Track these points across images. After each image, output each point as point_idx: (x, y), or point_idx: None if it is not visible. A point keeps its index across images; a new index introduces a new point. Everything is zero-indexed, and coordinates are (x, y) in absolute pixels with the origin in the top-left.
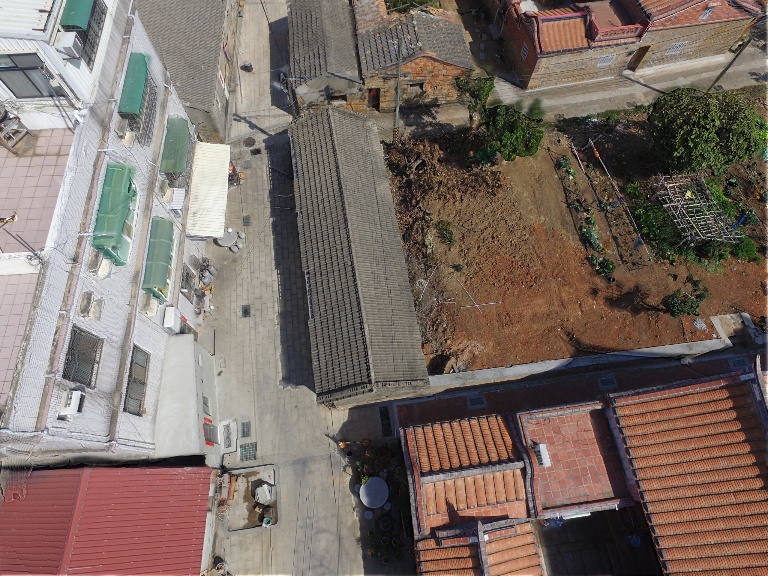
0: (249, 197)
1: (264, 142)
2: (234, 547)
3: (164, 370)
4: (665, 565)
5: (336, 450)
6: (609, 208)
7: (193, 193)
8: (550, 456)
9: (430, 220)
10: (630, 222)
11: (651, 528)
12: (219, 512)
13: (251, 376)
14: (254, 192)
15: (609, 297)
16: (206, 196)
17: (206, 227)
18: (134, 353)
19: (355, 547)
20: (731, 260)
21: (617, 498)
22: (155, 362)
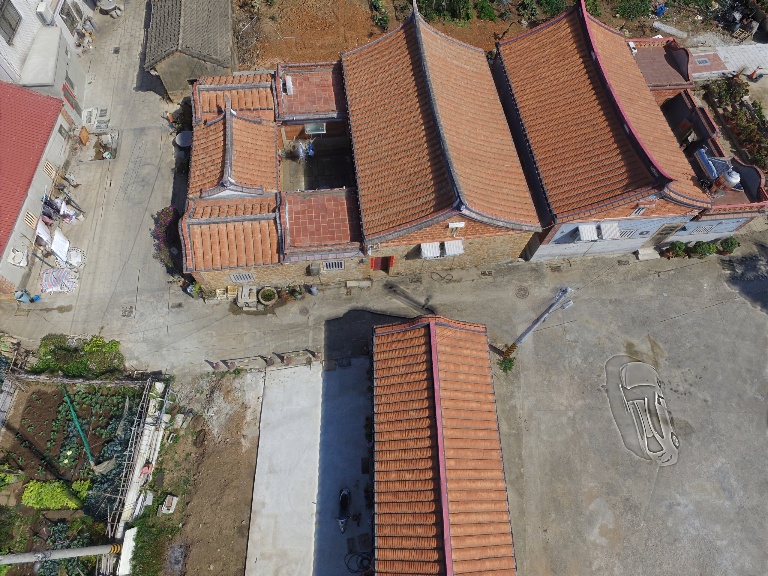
0: None
1: None
2: (82, 170)
3: (35, 41)
4: (350, 128)
5: (167, 124)
6: None
7: None
8: (298, 91)
9: None
10: None
11: None
12: (73, 150)
13: (113, 85)
14: None
15: None
16: None
17: None
18: (6, 1)
19: (169, 173)
20: (476, 20)
21: (337, 110)
22: (27, 28)
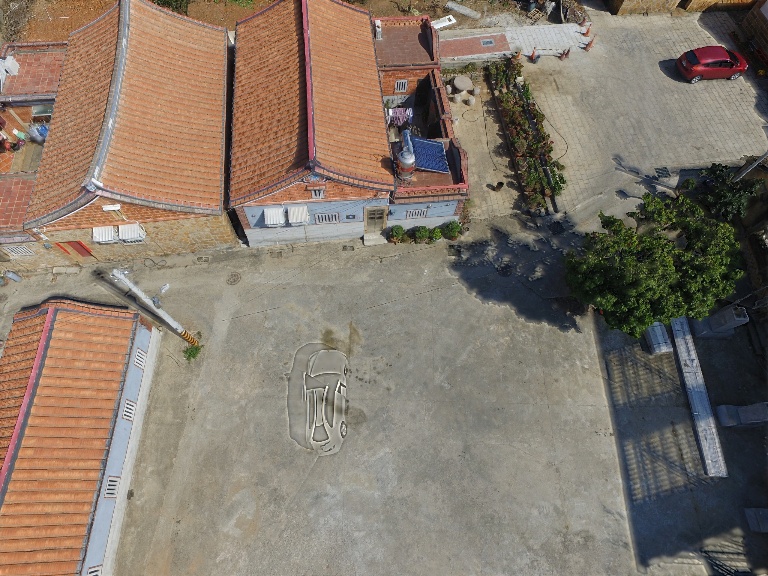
0: None
1: None
2: None
3: None
4: None
5: None
6: None
7: None
8: (24, 72)
9: None
10: None
11: None
12: None
13: None
14: None
15: None
16: None
17: None
18: None
19: None
20: (261, 0)
21: None
22: None
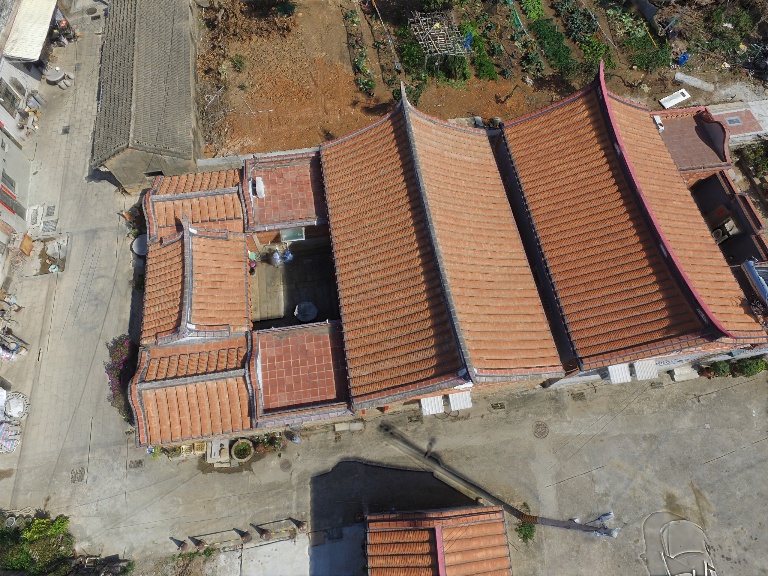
0: (84, 50)
1: (104, 11)
2: (25, 288)
3: None
4: (332, 246)
5: (124, 223)
6: (382, 46)
7: (15, 27)
8: (270, 192)
9: (224, 53)
10: (398, 56)
11: (329, 225)
12: (15, 263)
13: (62, 174)
14: (89, 46)
15: (366, 106)
16: (27, 30)
17: (23, 51)
18: None
19: (127, 287)
20: (475, 80)
21: (316, 216)
22: None
